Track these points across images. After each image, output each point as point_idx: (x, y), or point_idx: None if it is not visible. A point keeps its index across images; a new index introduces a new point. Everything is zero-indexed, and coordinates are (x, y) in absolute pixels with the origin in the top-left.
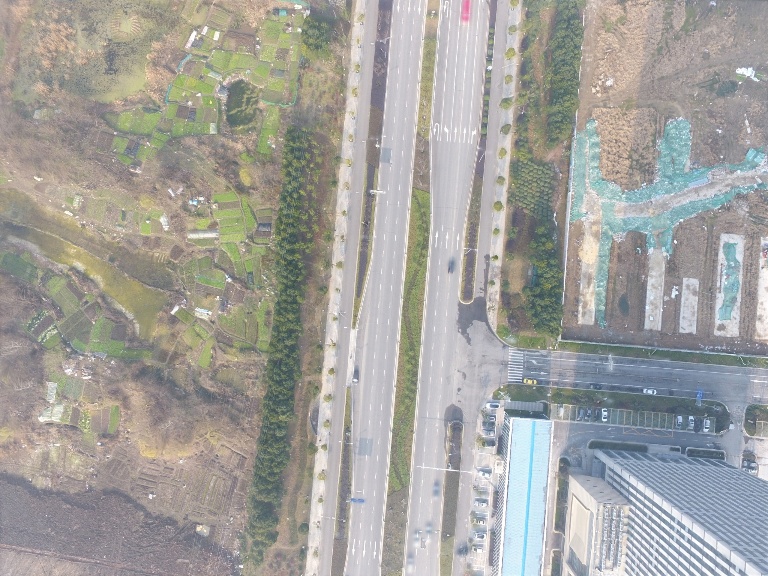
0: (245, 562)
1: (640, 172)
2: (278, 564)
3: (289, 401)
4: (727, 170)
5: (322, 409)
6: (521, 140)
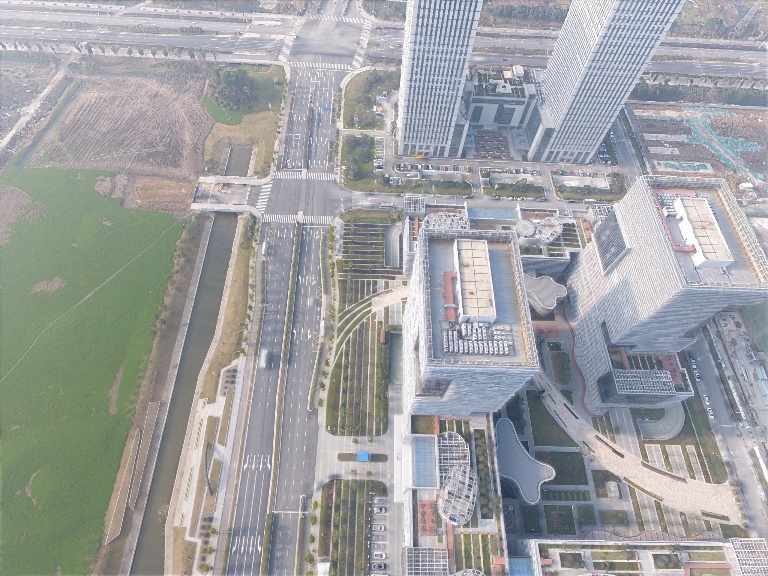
0: (486, 7)
1: (722, 132)
2: (485, 18)
3: (561, 14)
4: (745, 165)
5: (555, 32)
6: (711, 88)
